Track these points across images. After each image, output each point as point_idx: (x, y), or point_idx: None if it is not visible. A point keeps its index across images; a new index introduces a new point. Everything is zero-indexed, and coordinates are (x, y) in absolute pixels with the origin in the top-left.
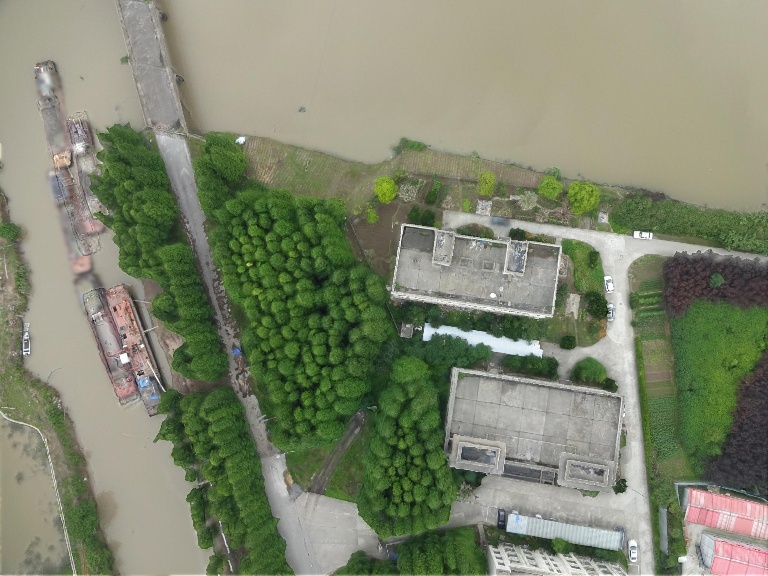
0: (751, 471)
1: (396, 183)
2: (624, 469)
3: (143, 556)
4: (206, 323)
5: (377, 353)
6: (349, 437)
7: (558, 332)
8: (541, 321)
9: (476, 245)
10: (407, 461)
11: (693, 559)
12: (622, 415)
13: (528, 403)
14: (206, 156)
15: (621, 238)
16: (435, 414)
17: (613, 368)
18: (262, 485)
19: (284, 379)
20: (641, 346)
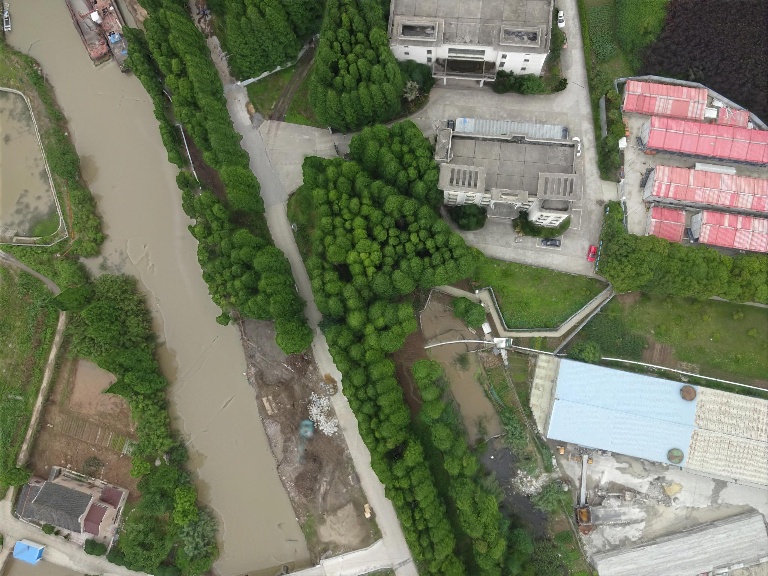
0: (684, 52)
1: None
2: (566, 75)
3: (124, 208)
4: None
5: None
6: (305, 68)
7: None
8: None
9: None
10: (352, 41)
11: (634, 150)
12: None
13: None
14: None
15: None
16: (378, 6)
17: None
18: (224, 105)
19: None
20: None
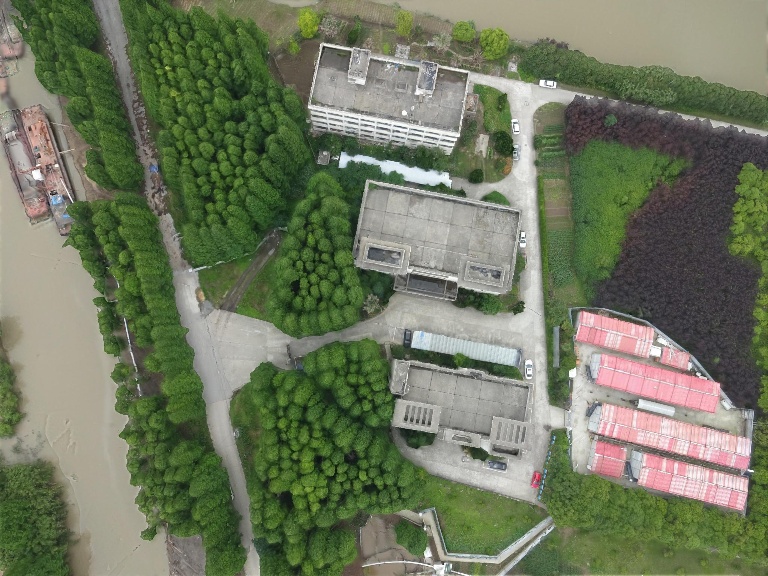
0: (636, 292)
1: None
2: (523, 295)
3: (47, 380)
4: (122, 132)
5: (293, 171)
6: (263, 258)
7: (467, 168)
8: (452, 157)
9: (391, 68)
10: (315, 259)
11: (583, 378)
12: (519, 227)
13: (434, 215)
14: None
15: (528, 86)
16: (345, 221)
17: (517, 203)
18: (173, 295)
19: (197, 176)
20: (542, 183)
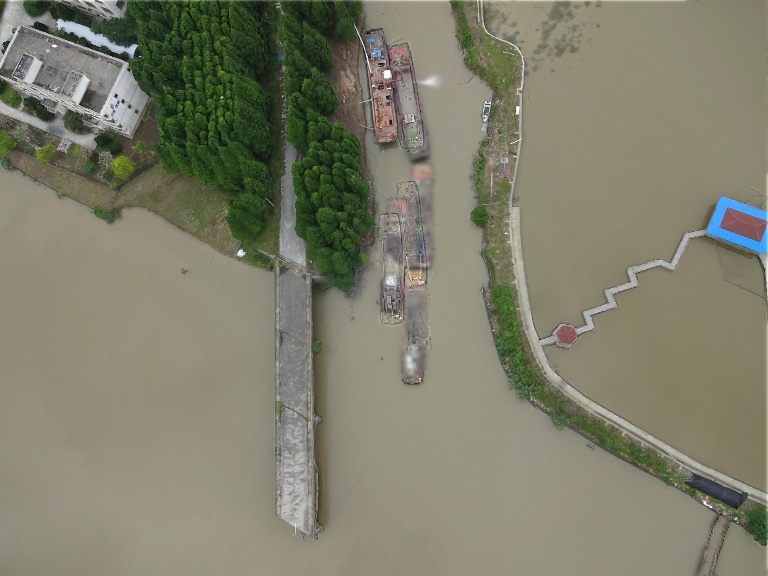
0: None
1: (122, 180)
2: None
3: None
4: None
5: None
6: None
7: None
8: None
9: (55, 89)
10: None
11: None
12: None
13: None
14: (235, 203)
15: None
16: None
17: (20, 8)
18: None
19: None
20: None
